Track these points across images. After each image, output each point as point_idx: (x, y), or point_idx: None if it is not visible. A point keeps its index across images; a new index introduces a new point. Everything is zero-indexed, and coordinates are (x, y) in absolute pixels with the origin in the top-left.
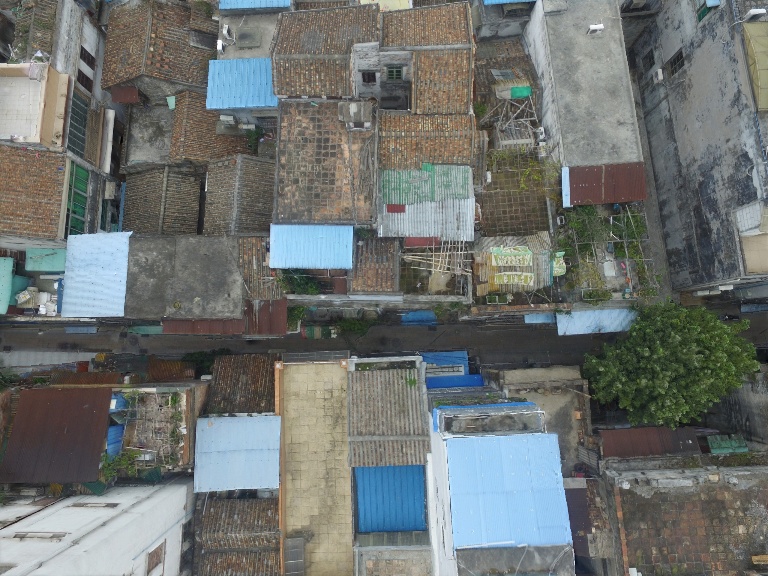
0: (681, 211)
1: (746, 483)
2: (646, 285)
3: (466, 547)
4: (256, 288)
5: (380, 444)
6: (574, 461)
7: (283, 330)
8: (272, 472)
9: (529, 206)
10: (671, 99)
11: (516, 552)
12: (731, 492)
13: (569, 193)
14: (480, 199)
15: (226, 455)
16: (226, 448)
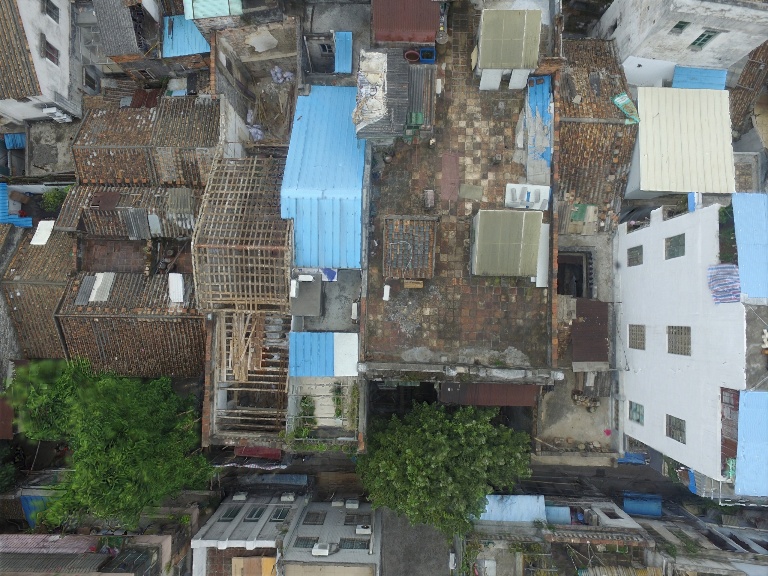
0: None
1: (414, 353)
2: None
3: None
4: None
5: None
6: None
7: None
8: None
9: None
10: None
11: None
12: (430, 346)
13: None
14: None
15: None
16: None
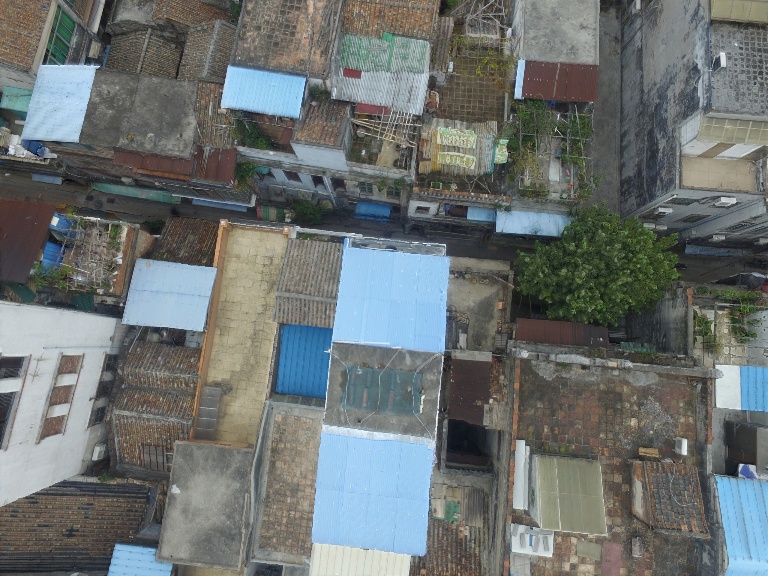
0: (637, 138)
1: (646, 380)
2: (584, 187)
3: (343, 342)
4: (209, 134)
5: (305, 303)
6: (489, 348)
7: (228, 179)
8: (199, 316)
9: (487, 104)
10: (645, 28)
11: (389, 351)
12: (630, 386)
13: (522, 85)
14: (441, 91)
15: (158, 295)
16: (159, 289)
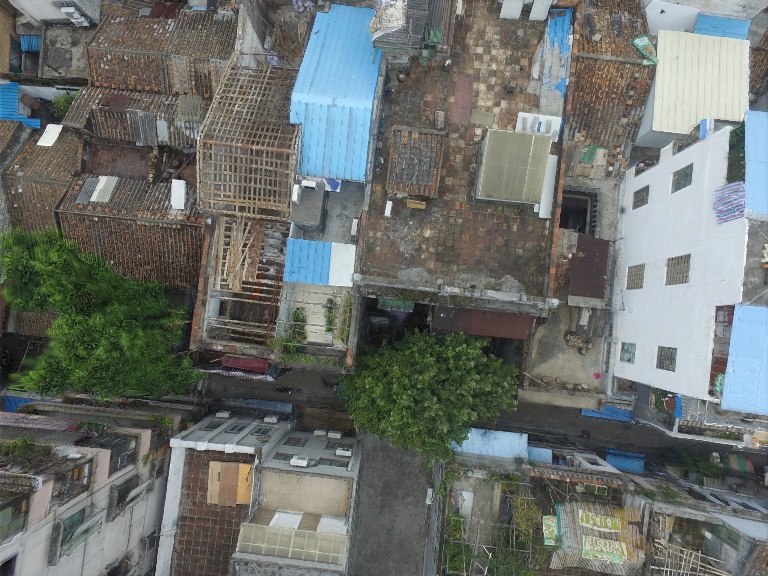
0: None
1: (410, 273)
2: None
3: None
4: None
5: None
6: None
7: None
8: None
9: None
10: None
11: None
12: (427, 267)
13: None
14: None
15: None
16: None
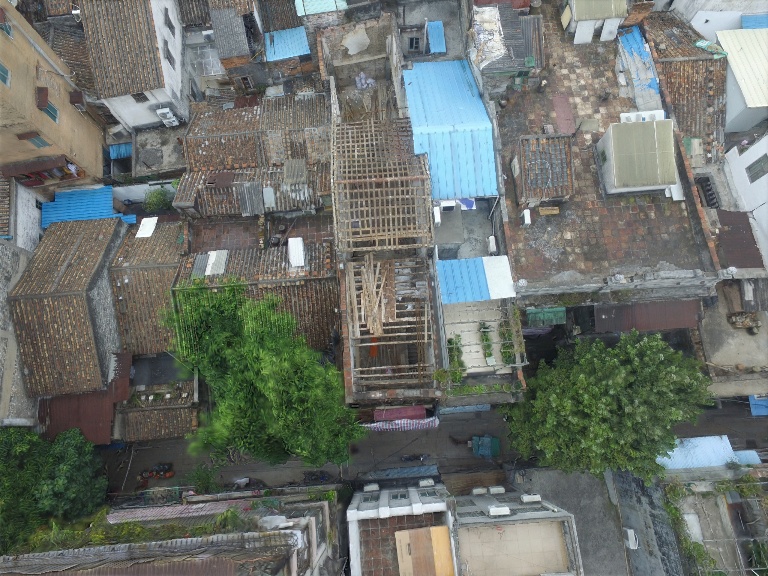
0: None
1: (563, 277)
2: None
3: None
4: None
5: None
6: None
7: None
8: None
9: None
10: None
11: None
12: (578, 269)
13: None
14: None
15: None
16: None
